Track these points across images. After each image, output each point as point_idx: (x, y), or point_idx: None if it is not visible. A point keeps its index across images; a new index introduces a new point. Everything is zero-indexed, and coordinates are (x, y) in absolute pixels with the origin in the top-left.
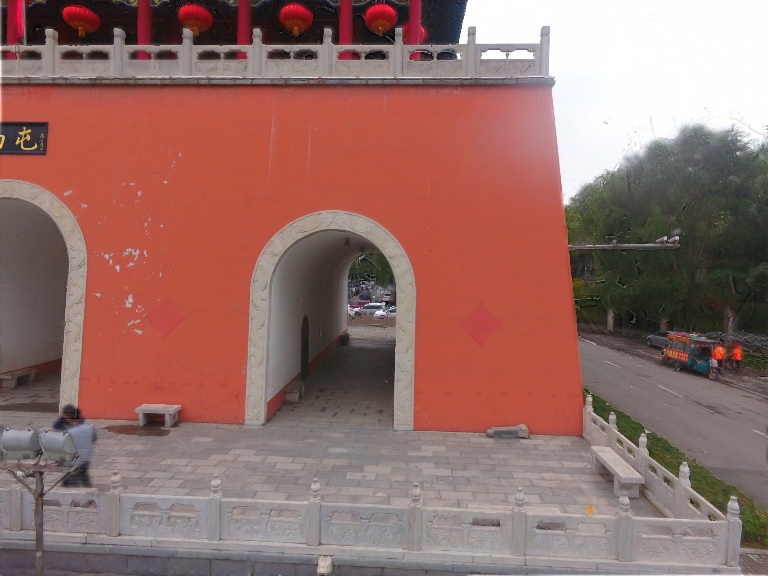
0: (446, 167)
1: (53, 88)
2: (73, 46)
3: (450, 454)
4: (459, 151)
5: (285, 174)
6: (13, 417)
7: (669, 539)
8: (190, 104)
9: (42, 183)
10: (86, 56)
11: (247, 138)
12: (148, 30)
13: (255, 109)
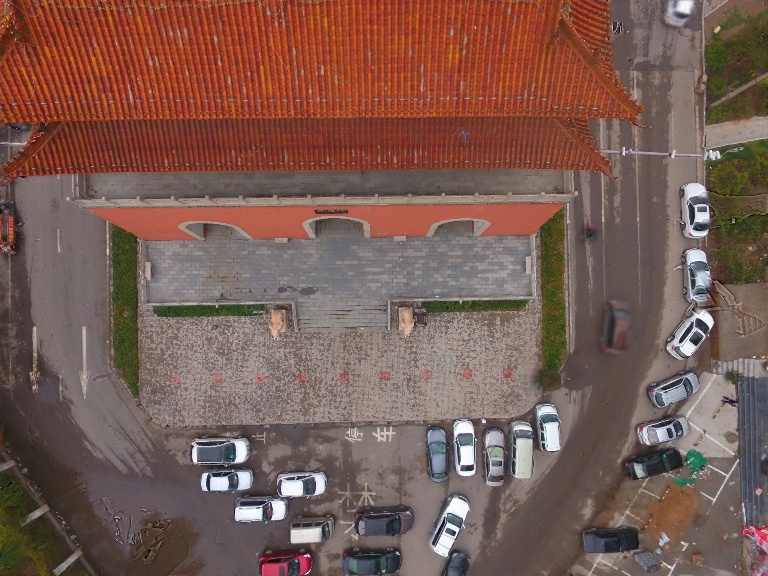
0: None
1: None
2: None
3: None
4: None
5: None
6: None
7: None
8: None
9: None
10: None
11: None
12: None
13: None
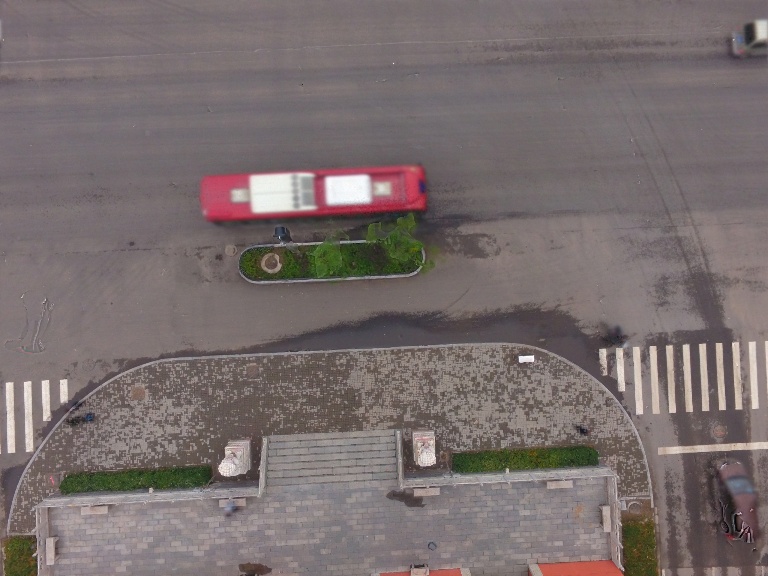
0: None
1: None
2: None
3: (114, 564)
4: None
5: None
6: (323, 575)
7: (56, 503)
8: None
9: None
10: None
11: None
12: None
13: None
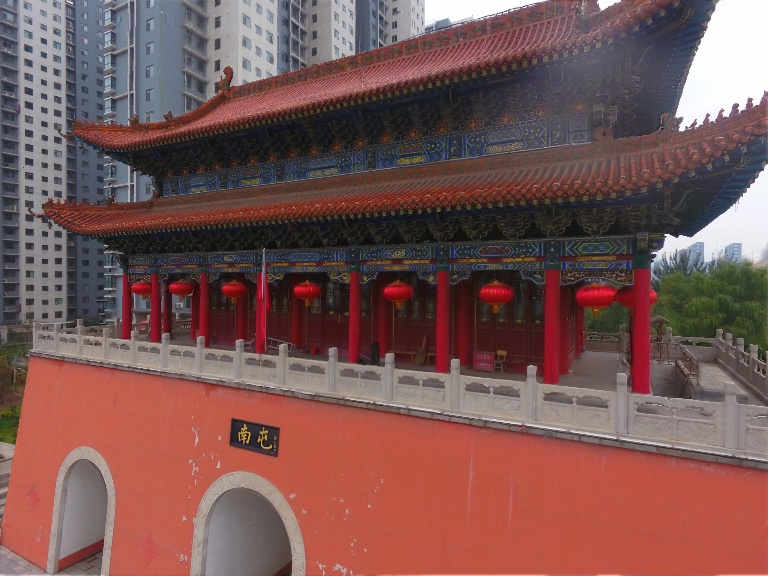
0: (693, 565)
1: (284, 397)
2: (298, 360)
3: None
4: (714, 551)
5: (484, 526)
6: None
7: None
8: (391, 430)
9: (274, 482)
10: (308, 369)
11: (445, 477)
12: (358, 306)
13: (453, 446)
